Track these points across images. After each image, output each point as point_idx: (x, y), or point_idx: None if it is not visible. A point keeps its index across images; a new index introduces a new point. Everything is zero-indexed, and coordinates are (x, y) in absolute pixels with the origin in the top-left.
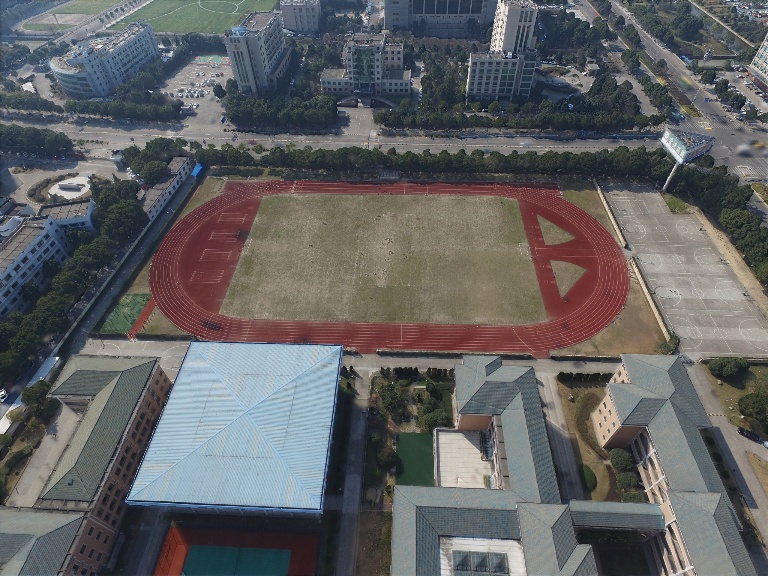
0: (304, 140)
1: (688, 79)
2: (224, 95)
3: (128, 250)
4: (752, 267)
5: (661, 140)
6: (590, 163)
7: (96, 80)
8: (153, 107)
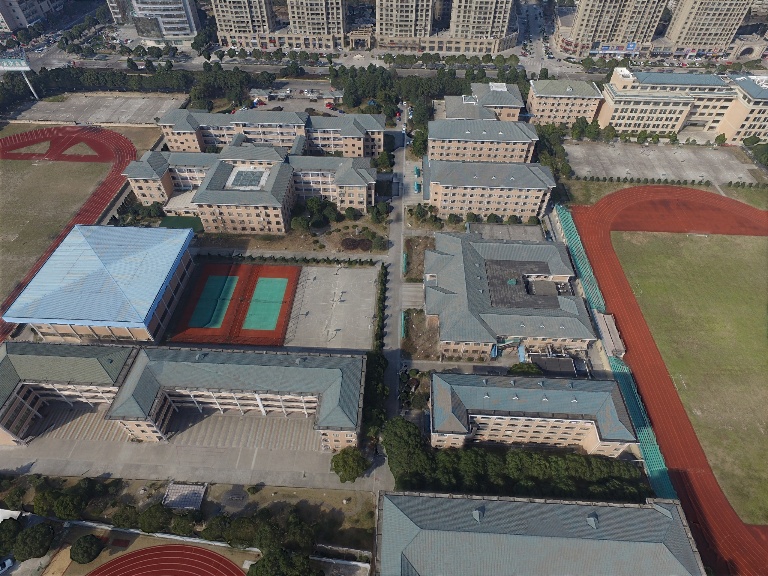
0: None
1: None
2: None
3: None
4: (127, 91)
5: None
6: None
7: None
8: None
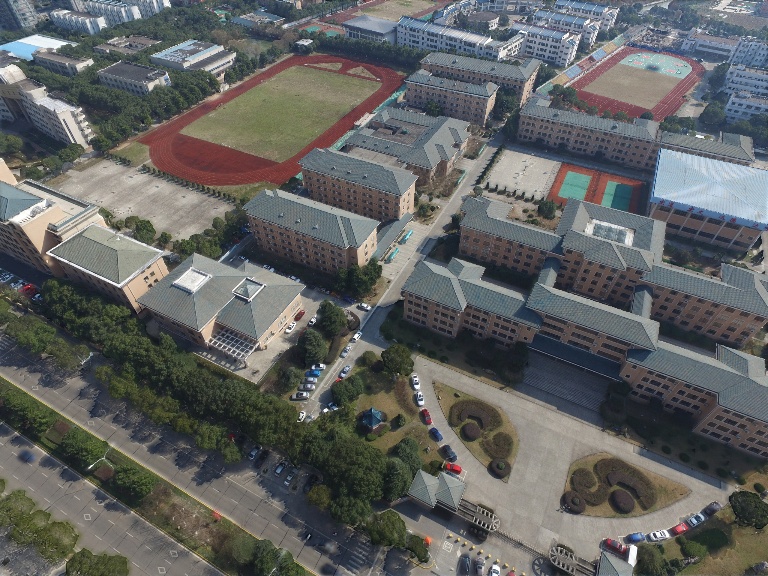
0: None
1: None
2: None
3: None
4: None
5: None
6: None
7: None
8: None
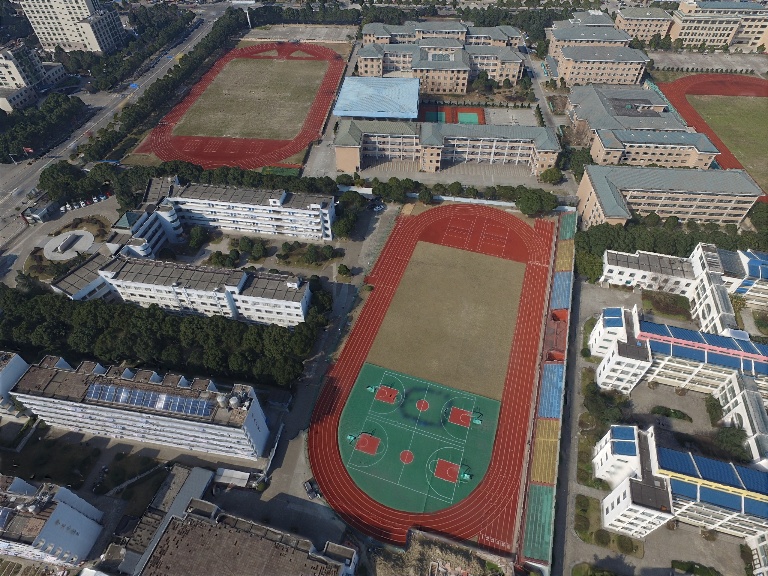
0: (96, 122)
1: (145, 5)
2: None
3: None
4: (311, 24)
5: None
6: (227, 29)
7: None
8: None
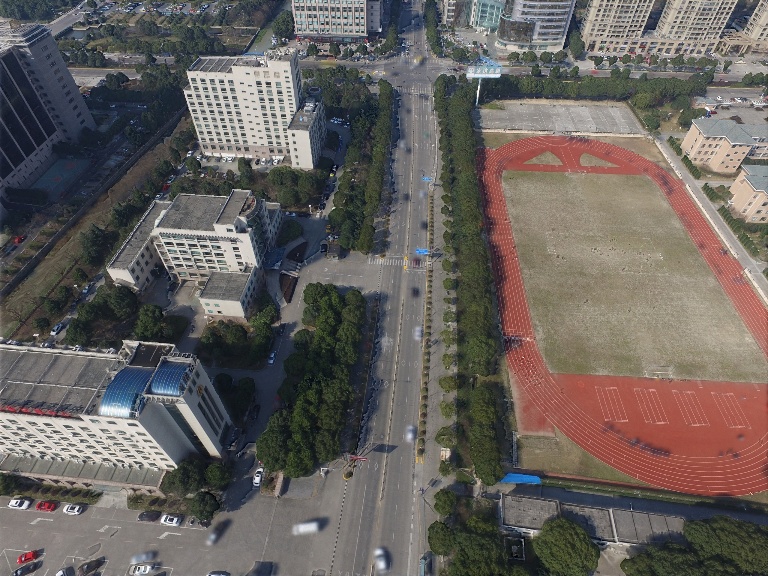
0: (395, 337)
1: None
2: None
3: None
4: (554, 98)
5: (467, 76)
6: None
7: None
8: None
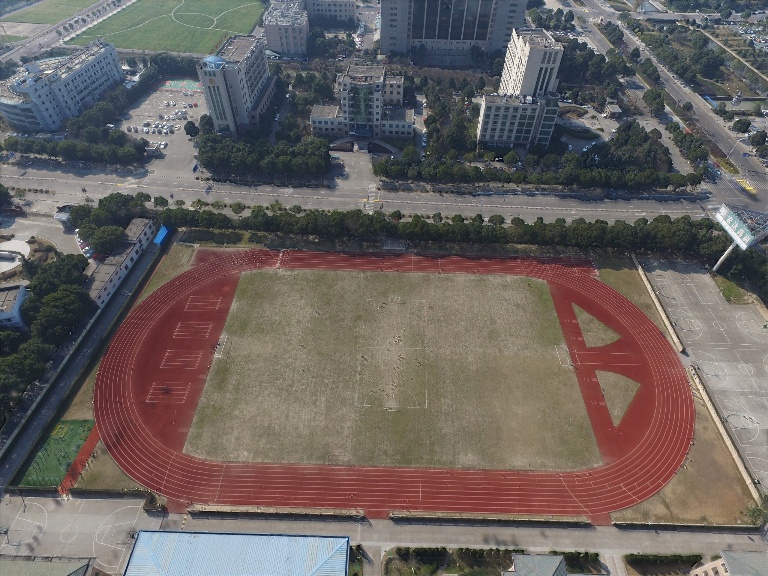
0: (291, 194)
1: (716, 125)
2: (197, 133)
3: (68, 353)
4: None
5: (715, 216)
6: (631, 238)
7: (44, 112)
8: (111, 149)
